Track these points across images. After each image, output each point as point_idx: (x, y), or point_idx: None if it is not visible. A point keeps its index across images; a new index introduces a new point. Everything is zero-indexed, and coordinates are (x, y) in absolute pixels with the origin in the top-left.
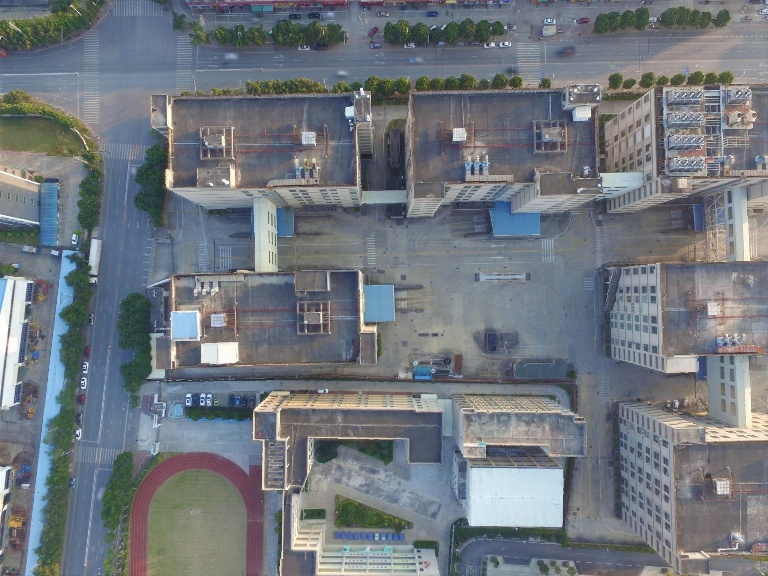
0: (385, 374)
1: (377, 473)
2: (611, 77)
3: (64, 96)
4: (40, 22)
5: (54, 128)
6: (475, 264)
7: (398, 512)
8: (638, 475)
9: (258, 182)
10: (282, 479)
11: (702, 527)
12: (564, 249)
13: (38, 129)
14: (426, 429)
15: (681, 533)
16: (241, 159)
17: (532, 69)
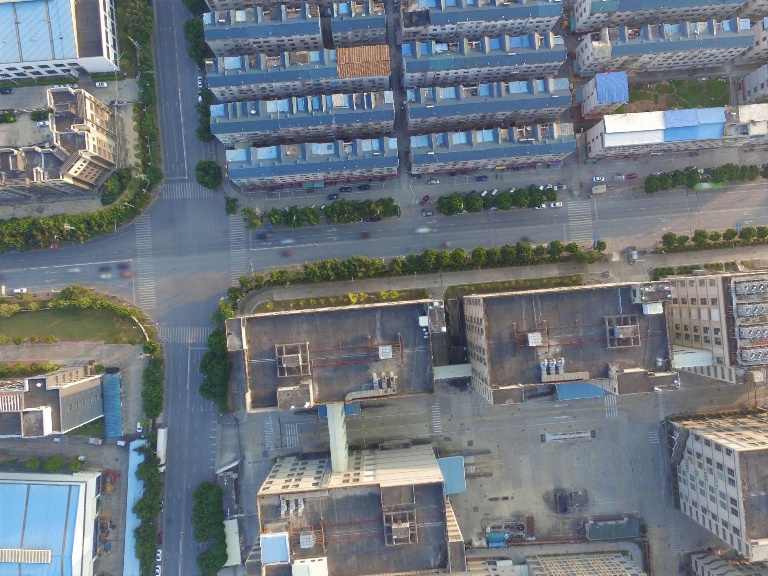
0: None
1: None
2: (665, 237)
3: (119, 283)
4: (93, 218)
5: (111, 316)
6: (540, 425)
7: None
8: None
9: (336, 395)
10: None
11: None
12: (627, 404)
13: (95, 318)
14: None
15: None
16: (317, 373)
17: (584, 227)
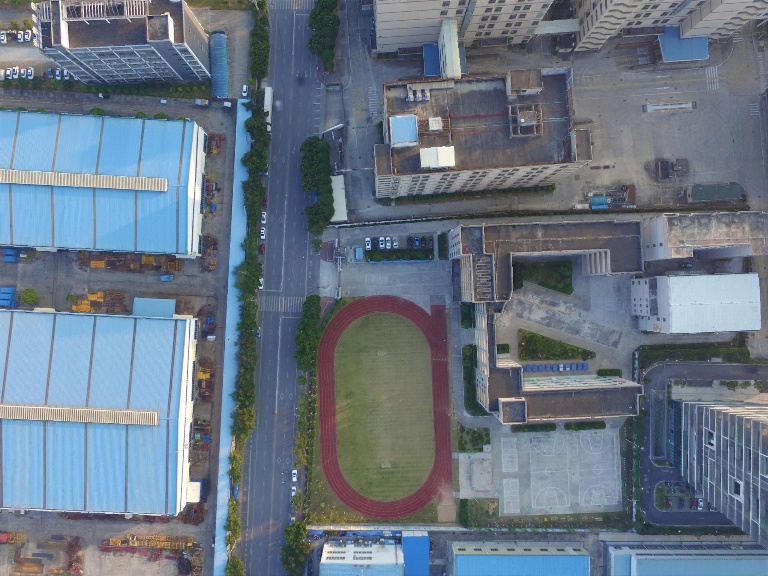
0: (560, 208)
1: (557, 306)
2: None
3: None
4: None
5: None
6: (642, 95)
7: (580, 343)
8: None
9: None
10: (491, 292)
11: None
12: (728, 76)
13: None
14: (625, 240)
15: None
16: None
17: None
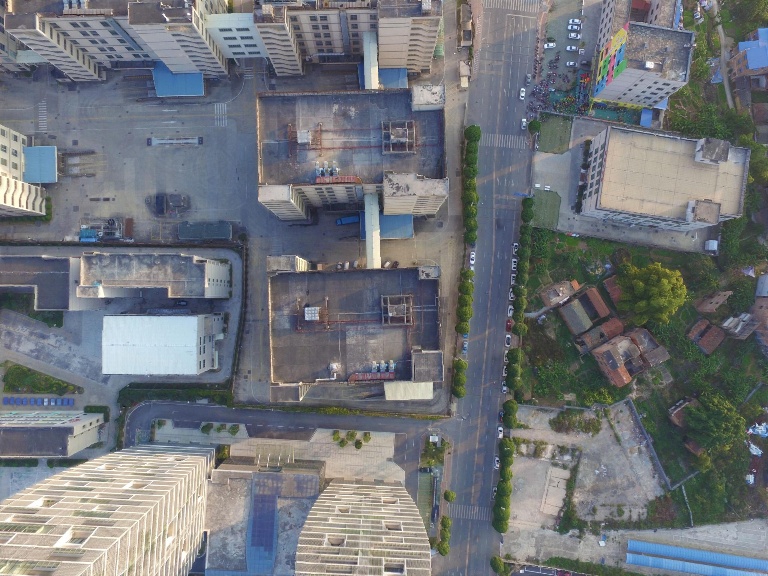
0: (56, 239)
1: (47, 338)
2: None
3: None
4: None
5: None
6: (147, 129)
7: (69, 377)
8: None
9: None
10: None
11: (301, 358)
12: (237, 113)
13: None
14: (55, 276)
15: (280, 364)
16: None
17: None
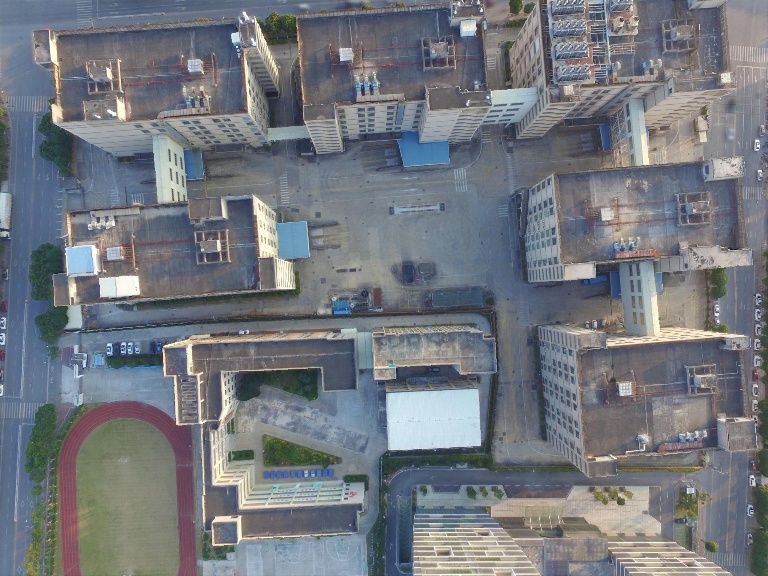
0: (305, 312)
1: (303, 411)
2: (511, 1)
3: None
4: None
5: None
6: (389, 197)
7: (326, 448)
8: (555, 392)
9: (149, 114)
10: (196, 414)
11: (609, 431)
12: (476, 178)
13: None
14: (339, 357)
15: (589, 438)
16: (130, 92)
17: None
